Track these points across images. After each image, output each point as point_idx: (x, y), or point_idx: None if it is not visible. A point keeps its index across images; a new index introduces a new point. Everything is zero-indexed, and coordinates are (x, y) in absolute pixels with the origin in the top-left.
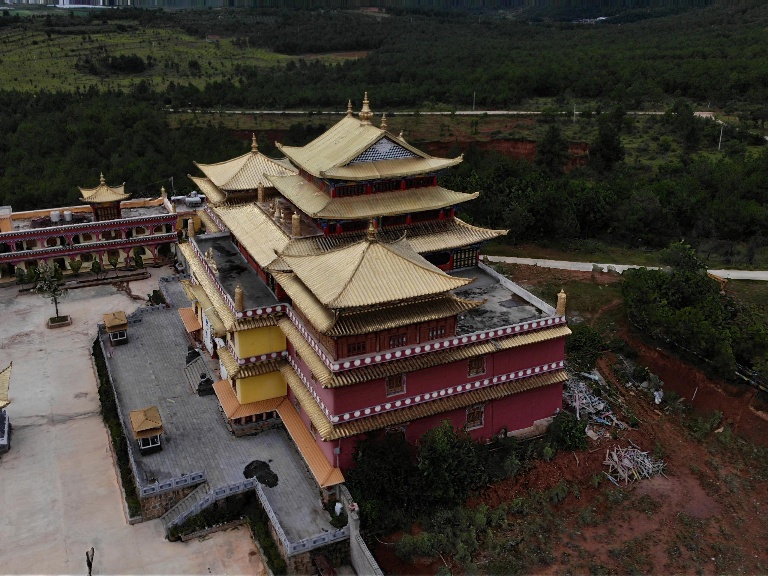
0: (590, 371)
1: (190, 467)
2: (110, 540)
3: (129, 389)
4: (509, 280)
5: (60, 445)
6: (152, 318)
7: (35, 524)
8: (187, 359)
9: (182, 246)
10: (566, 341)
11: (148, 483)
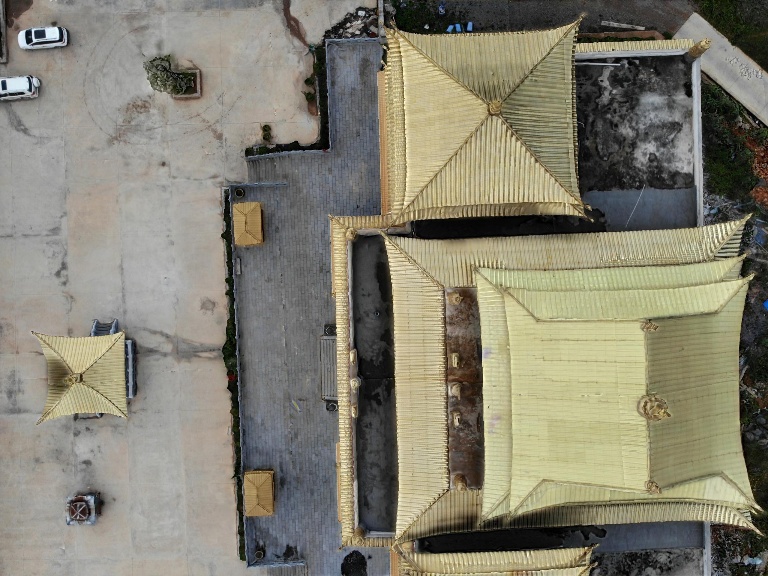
0: (760, 552)
1: (296, 537)
2: (223, 570)
3: (255, 361)
4: (710, 571)
5: (184, 404)
6: (301, 173)
7: (163, 523)
8: (325, 335)
9: (336, 232)
10: (766, 511)
11: (255, 555)
